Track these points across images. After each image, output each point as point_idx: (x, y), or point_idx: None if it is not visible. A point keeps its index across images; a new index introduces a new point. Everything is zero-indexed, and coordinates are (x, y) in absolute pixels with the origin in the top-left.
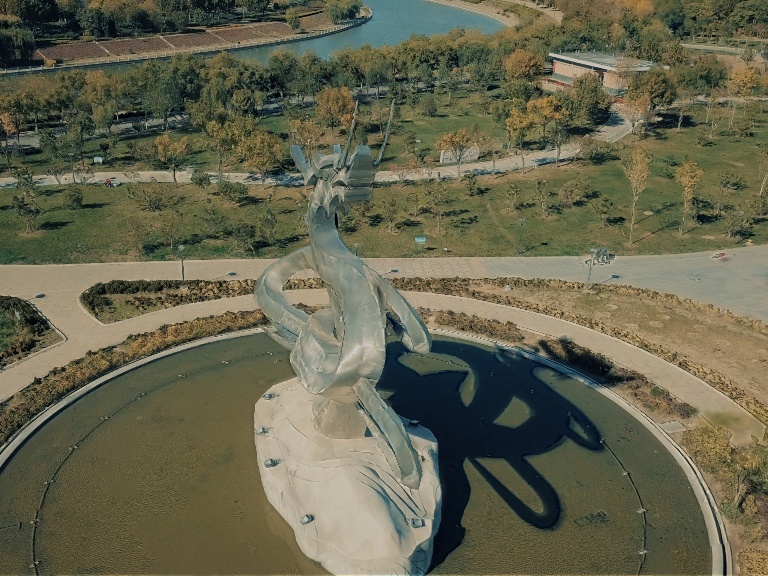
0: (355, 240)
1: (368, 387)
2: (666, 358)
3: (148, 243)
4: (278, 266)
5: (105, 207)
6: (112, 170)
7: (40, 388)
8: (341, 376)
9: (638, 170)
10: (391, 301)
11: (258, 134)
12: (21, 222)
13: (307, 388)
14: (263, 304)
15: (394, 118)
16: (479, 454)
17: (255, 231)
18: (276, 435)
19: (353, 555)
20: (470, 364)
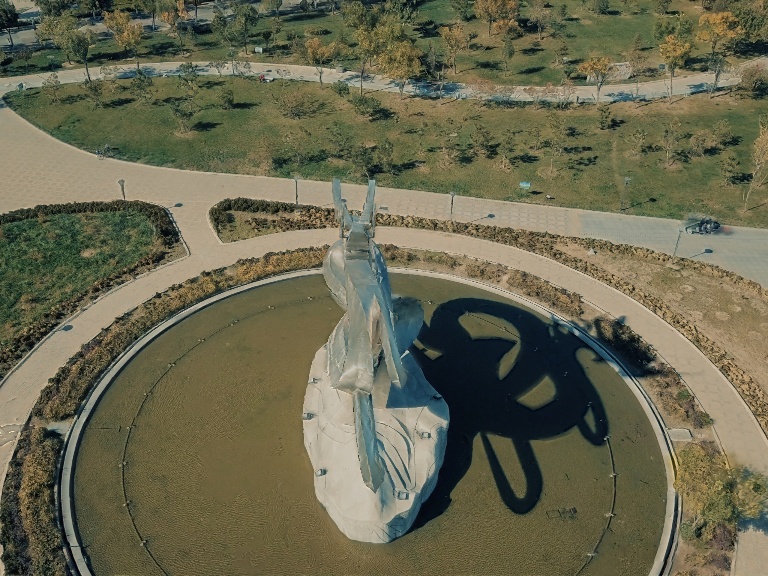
0: (466, 174)
1: (359, 400)
2: (711, 358)
3: (280, 156)
4: (340, 247)
5: (253, 108)
6: (270, 61)
7: (158, 304)
8: (343, 383)
9: (764, 139)
10: (383, 338)
11: (400, 46)
12: (177, 123)
13: (328, 376)
14: (327, 275)
15: (559, 16)
16: (493, 430)
17: (372, 158)
18: (322, 388)
19: (344, 512)
20: (521, 334)
